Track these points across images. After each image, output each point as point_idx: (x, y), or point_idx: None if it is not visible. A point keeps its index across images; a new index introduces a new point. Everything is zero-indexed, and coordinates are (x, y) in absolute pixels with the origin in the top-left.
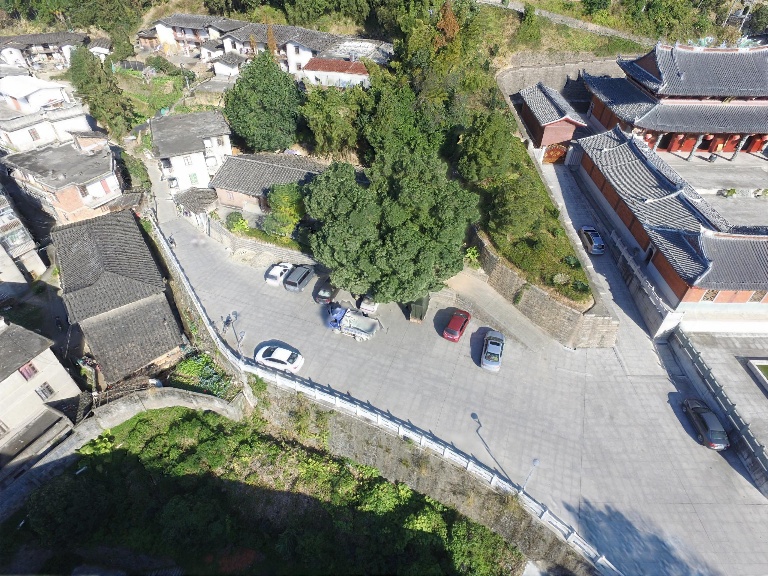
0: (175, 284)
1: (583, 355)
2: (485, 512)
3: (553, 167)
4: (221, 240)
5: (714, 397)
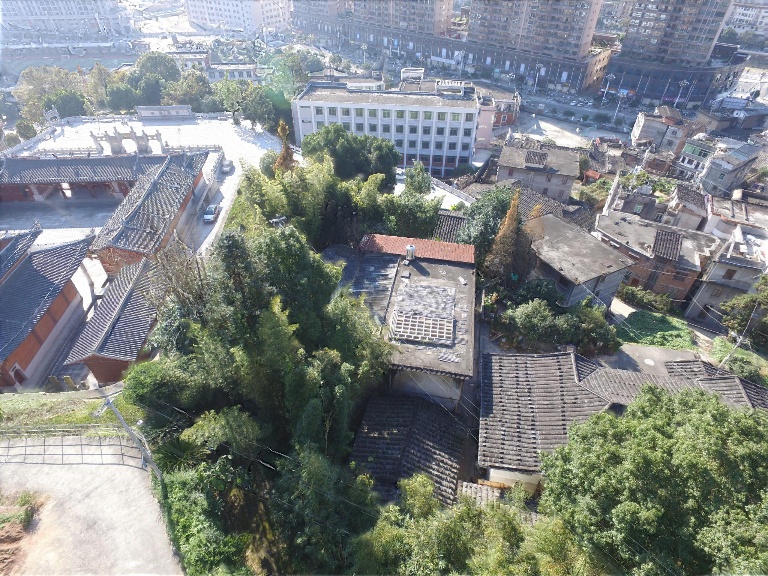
0: None
1: None
2: None
3: None
4: None
5: None
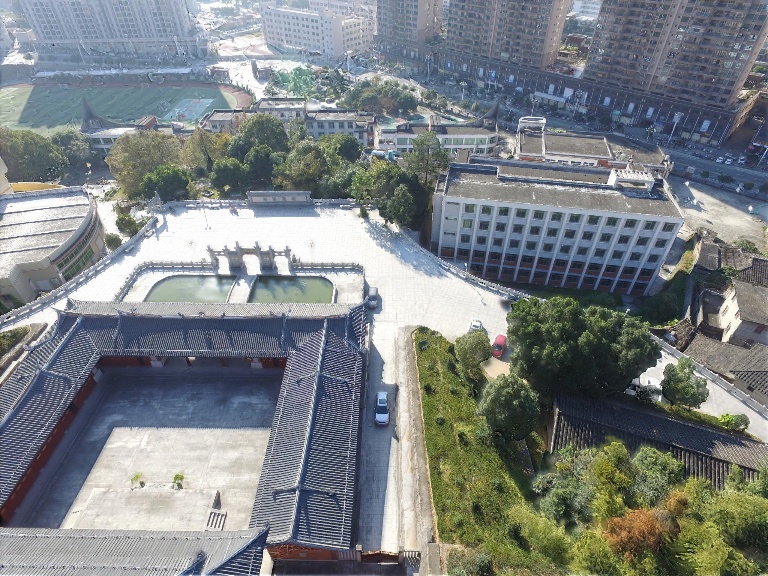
0: None
1: None
2: None
3: None
4: None
5: None
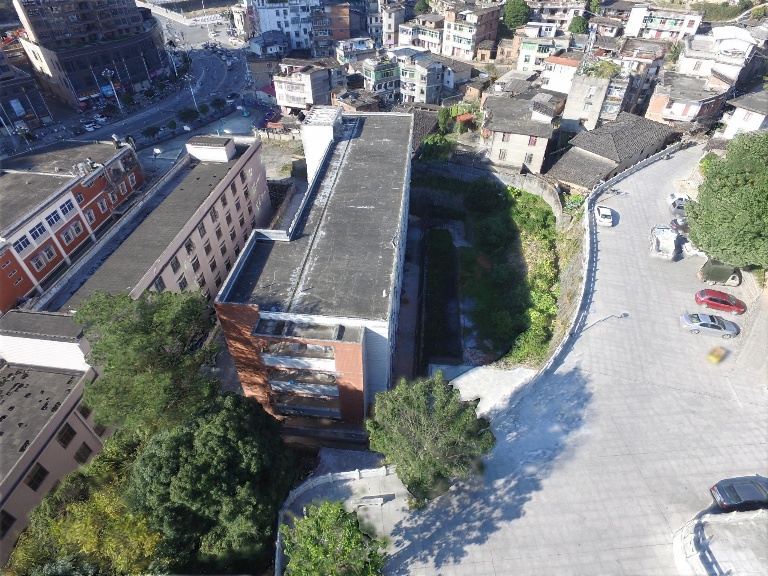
0: None
1: (767, 403)
2: None
3: None
4: None
5: None
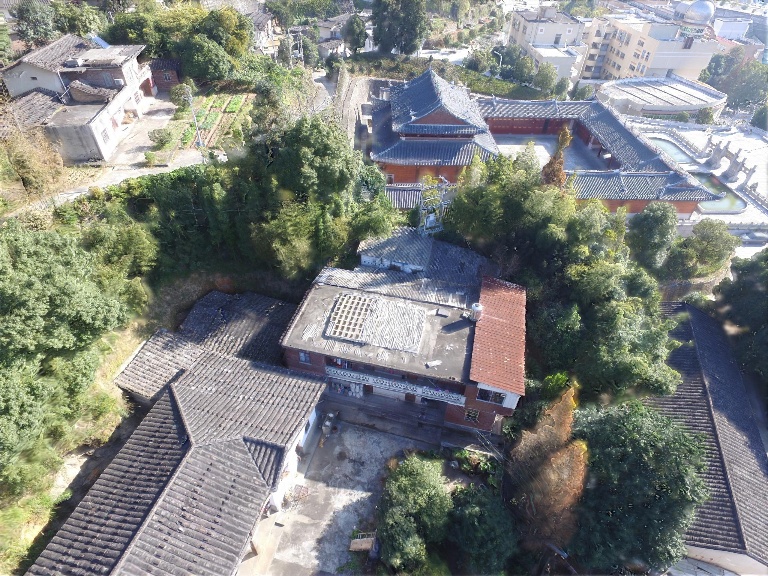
0: None
1: None
2: None
3: None
4: None
5: (739, 229)
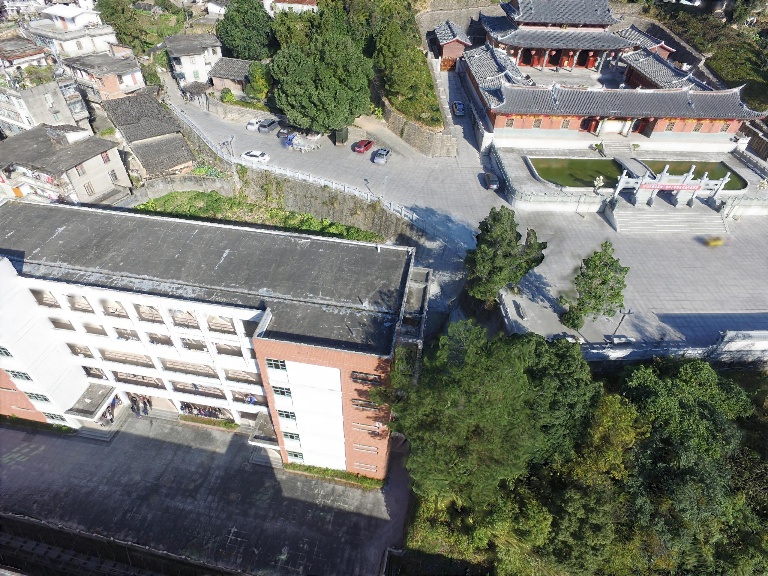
0: (186, 138)
1: (436, 159)
2: (367, 221)
3: (447, 73)
4: (217, 111)
5: None
